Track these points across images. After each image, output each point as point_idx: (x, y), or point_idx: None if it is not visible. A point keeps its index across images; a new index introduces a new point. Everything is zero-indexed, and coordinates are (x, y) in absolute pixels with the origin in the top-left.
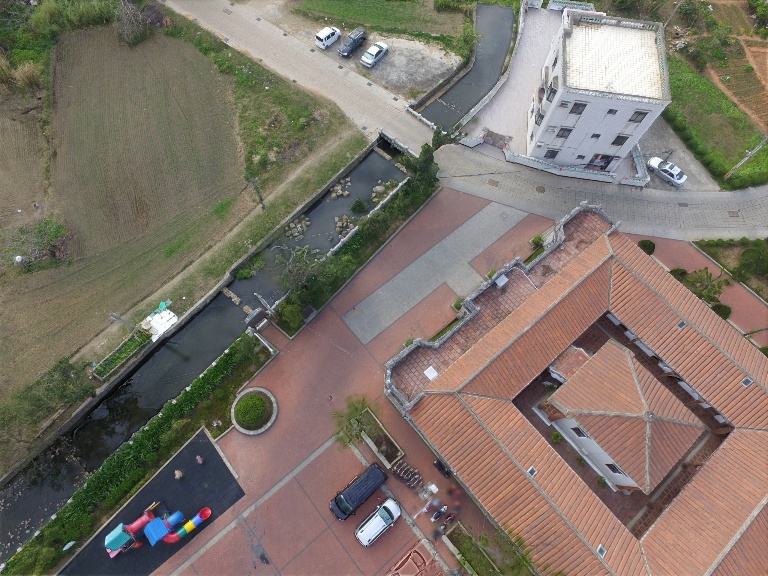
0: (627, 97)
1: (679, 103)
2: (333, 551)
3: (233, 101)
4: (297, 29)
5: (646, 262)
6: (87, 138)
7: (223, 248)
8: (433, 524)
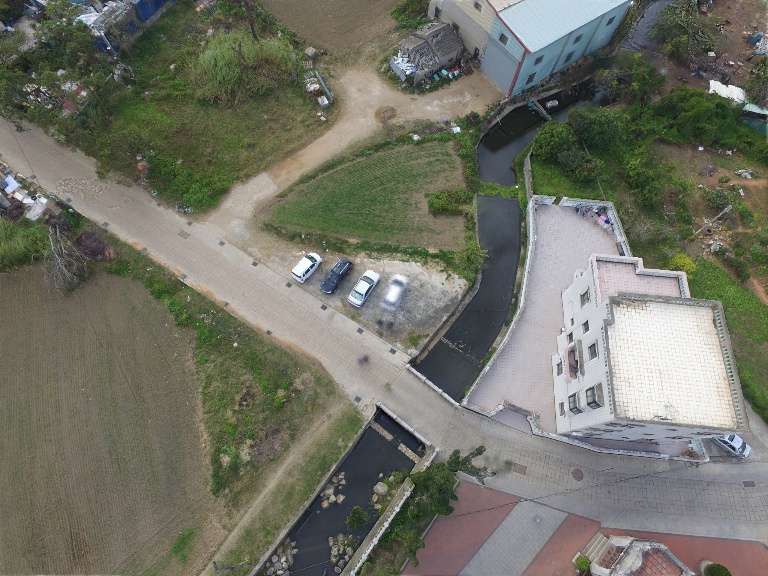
0: None
1: None
2: None
3: (194, 369)
4: (269, 254)
5: None
6: (8, 442)
7: None
8: None
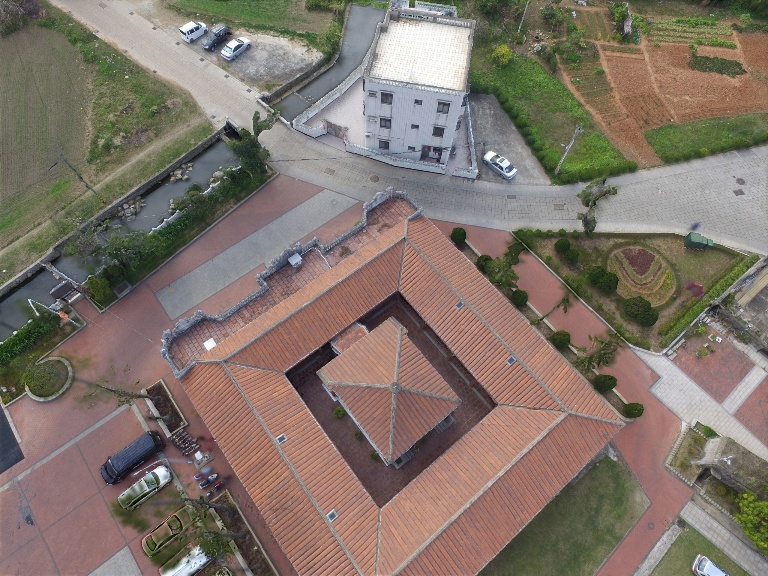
0: (425, 87)
1: (526, 102)
2: (99, 514)
3: (91, 88)
4: (167, 23)
5: (443, 246)
6: None
7: (52, 225)
8: (202, 491)
